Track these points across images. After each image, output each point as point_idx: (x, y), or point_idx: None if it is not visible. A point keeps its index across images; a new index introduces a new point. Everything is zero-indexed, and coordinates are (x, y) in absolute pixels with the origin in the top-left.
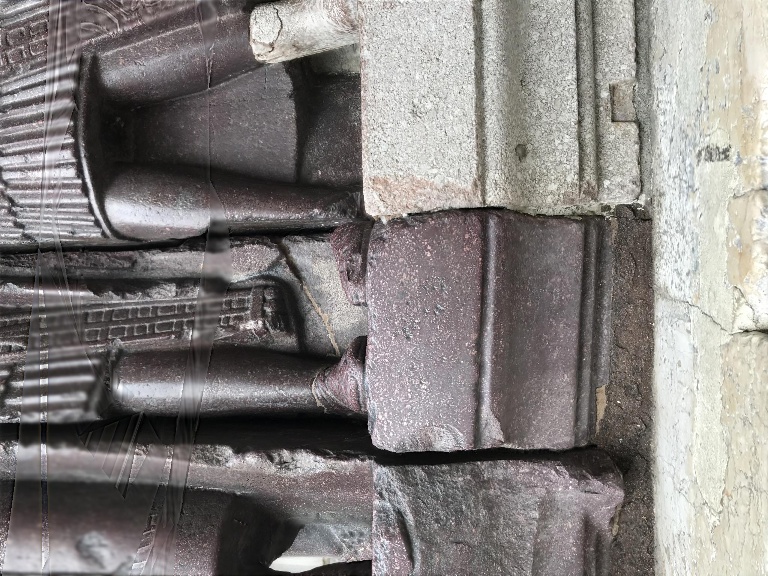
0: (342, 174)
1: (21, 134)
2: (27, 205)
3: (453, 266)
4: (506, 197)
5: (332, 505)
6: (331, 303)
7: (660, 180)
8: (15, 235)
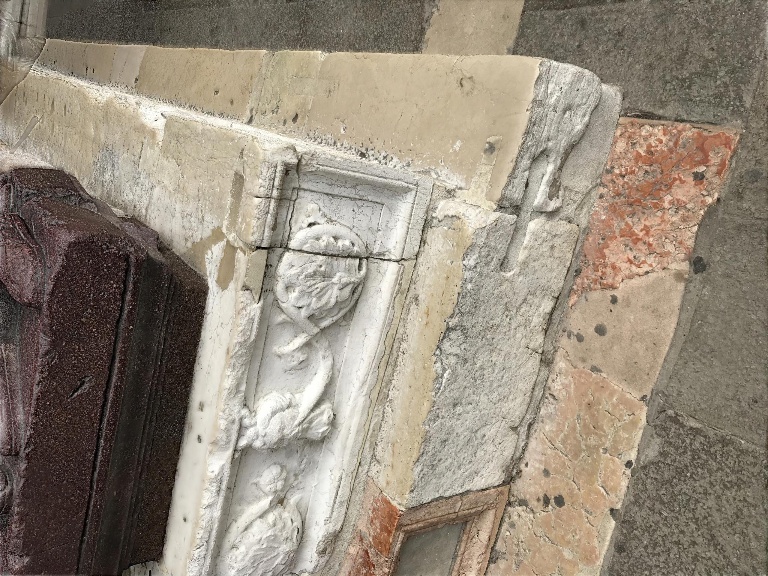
0: None
1: None
2: None
3: None
4: None
5: None
6: None
7: None
8: None
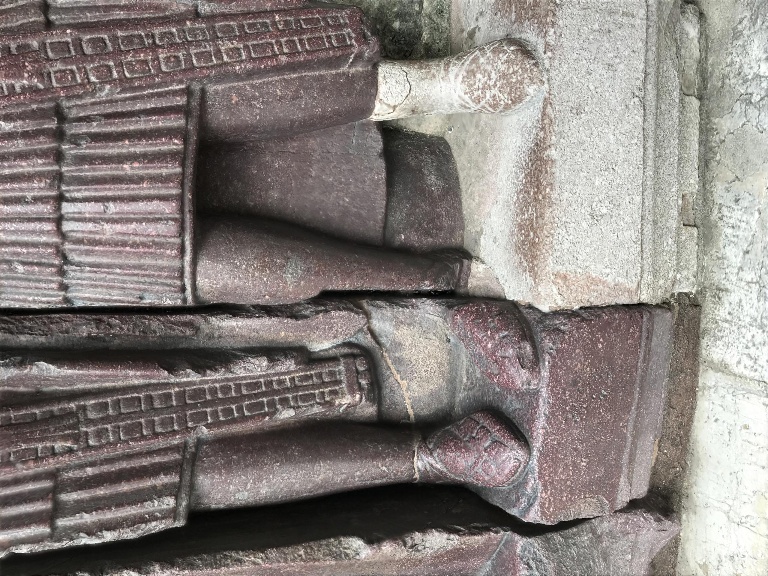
0: (424, 240)
1: (100, 176)
2: (87, 264)
3: (618, 356)
4: (653, 295)
5: (435, 575)
6: (411, 370)
7: (720, 278)
8: (51, 299)
